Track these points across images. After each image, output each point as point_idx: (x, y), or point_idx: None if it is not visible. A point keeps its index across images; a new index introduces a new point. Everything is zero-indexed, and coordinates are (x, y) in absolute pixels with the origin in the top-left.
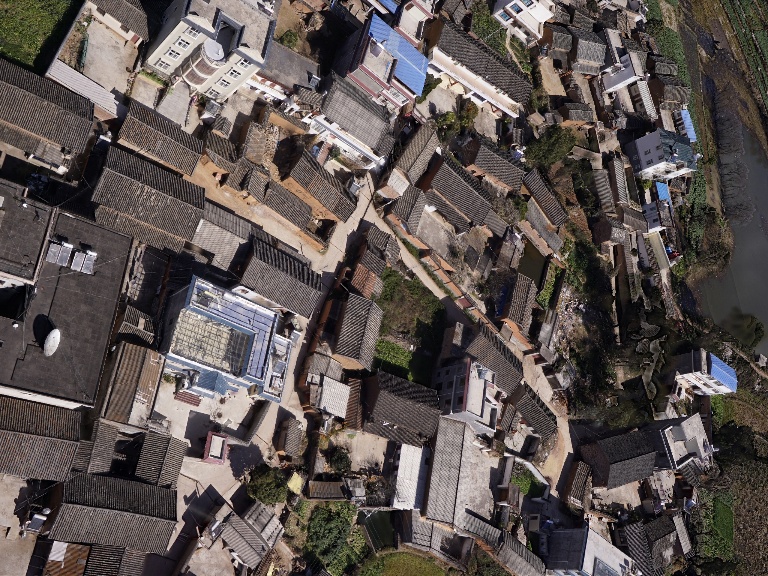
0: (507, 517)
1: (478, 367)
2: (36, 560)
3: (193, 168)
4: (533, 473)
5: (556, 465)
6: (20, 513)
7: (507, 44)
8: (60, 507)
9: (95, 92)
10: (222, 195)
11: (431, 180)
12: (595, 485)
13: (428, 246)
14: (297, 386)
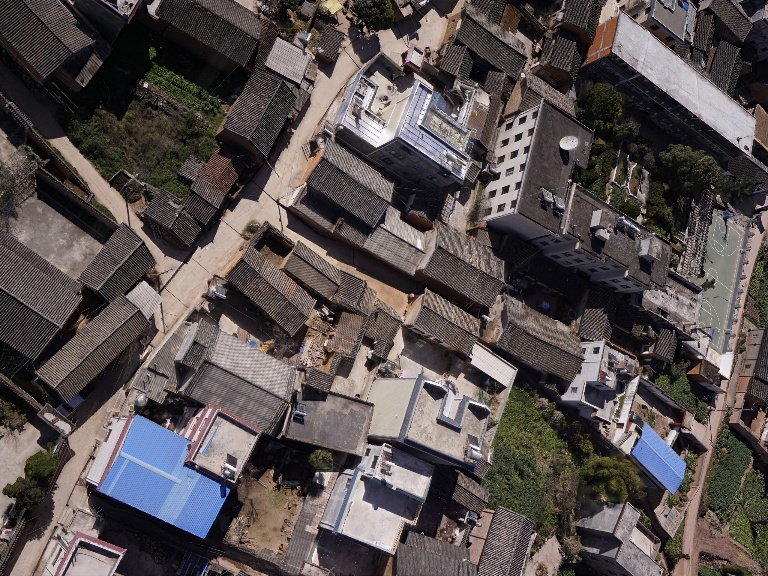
0: None
1: None
2: None
3: (427, 295)
4: None
5: None
6: None
7: None
8: None
9: (486, 362)
10: None
11: None
12: None
13: (96, 209)
14: None
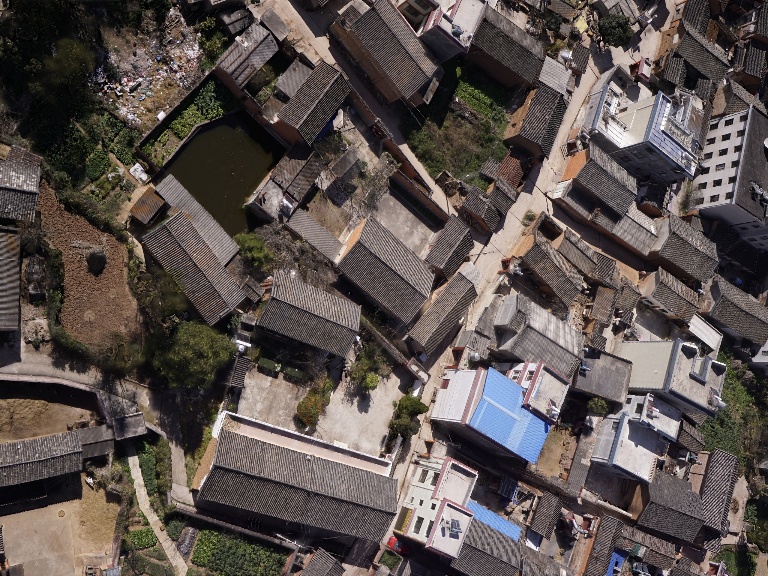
0: None
1: None
2: None
3: (661, 272)
4: None
5: None
6: None
7: (183, 572)
8: None
9: (700, 329)
10: None
11: None
12: None
13: (435, 203)
14: None
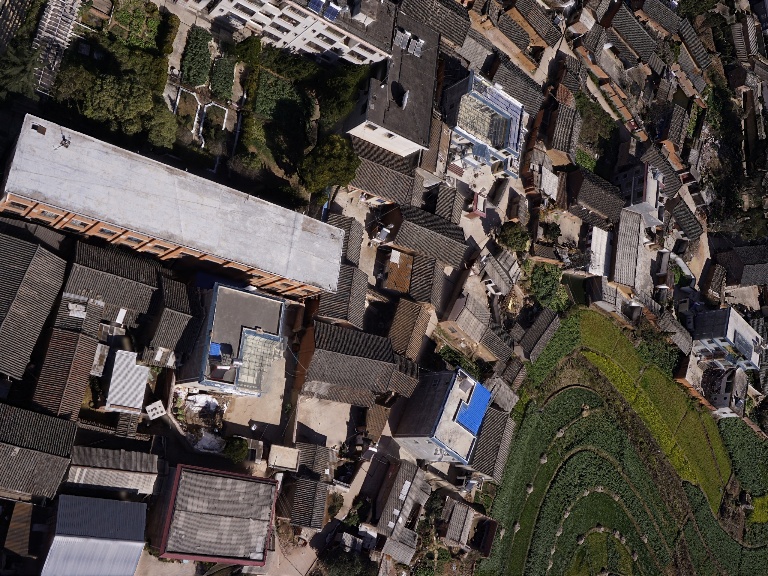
0: (665, 296)
1: (654, 168)
2: (378, 264)
3: None
4: (682, 268)
5: (698, 266)
6: (368, 230)
7: None
8: (402, 222)
9: None
10: None
11: (610, 20)
12: (728, 284)
13: (608, 75)
14: (521, 173)
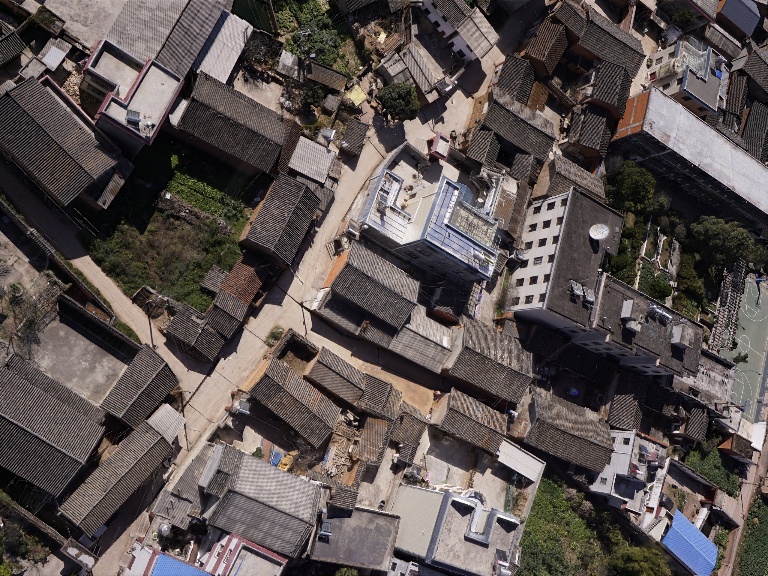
0: None
1: None
2: None
3: (453, 395)
4: None
5: None
6: None
7: None
8: None
9: (513, 458)
10: (393, 386)
11: None
12: None
13: (118, 331)
14: None
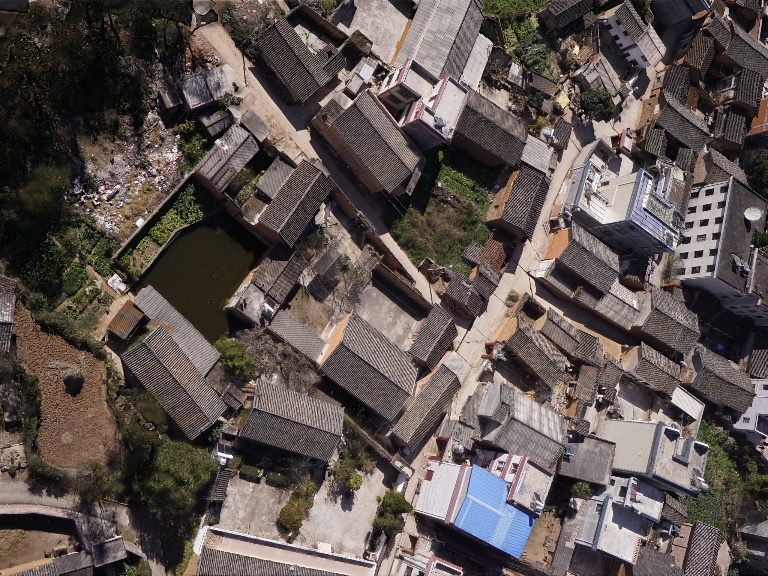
0: None
1: None
2: None
3: (643, 348)
4: None
5: None
6: None
7: None
8: None
9: (682, 400)
10: None
11: None
12: None
13: (418, 293)
14: None
